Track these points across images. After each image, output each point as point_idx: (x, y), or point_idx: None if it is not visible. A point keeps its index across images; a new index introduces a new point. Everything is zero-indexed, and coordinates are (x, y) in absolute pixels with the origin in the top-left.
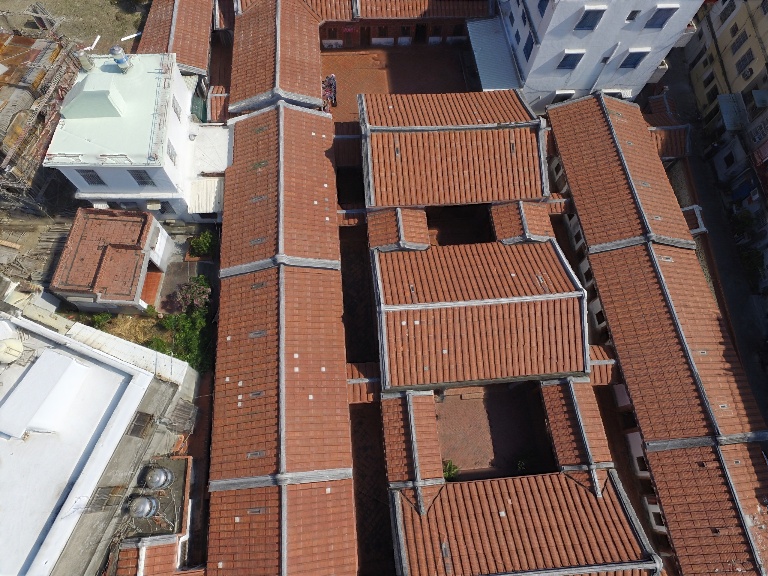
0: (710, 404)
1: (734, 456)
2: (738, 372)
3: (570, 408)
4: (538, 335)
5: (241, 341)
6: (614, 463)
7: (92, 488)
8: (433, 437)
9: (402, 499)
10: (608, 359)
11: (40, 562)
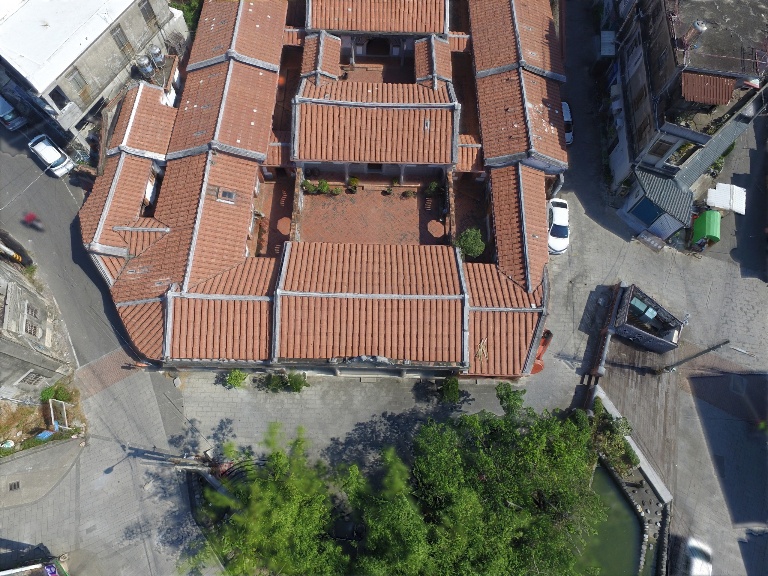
0: (522, 49)
1: (533, 79)
2: (554, 47)
3: (429, 51)
4: (414, 6)
5: (218, 0)
6: (466, 113)
7: (115, 17)
8: (335, 59)
9: (307, 81)
10: (465, 35)
11: (84, 30)
